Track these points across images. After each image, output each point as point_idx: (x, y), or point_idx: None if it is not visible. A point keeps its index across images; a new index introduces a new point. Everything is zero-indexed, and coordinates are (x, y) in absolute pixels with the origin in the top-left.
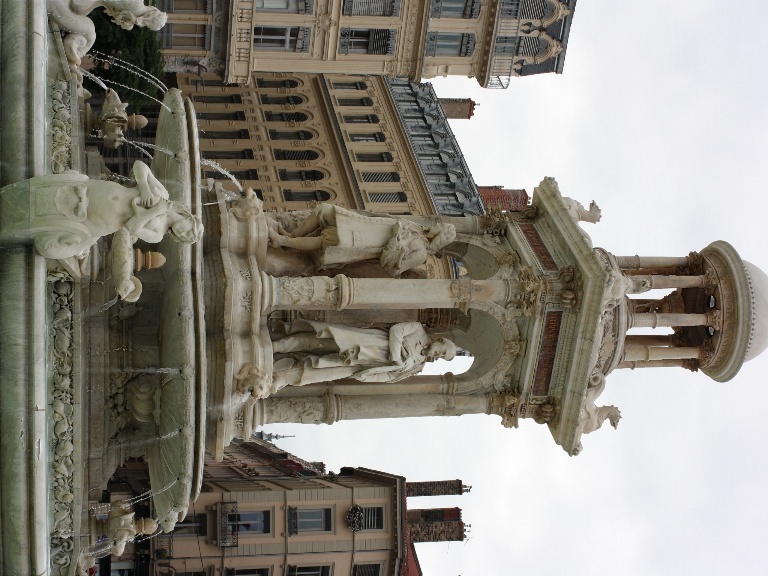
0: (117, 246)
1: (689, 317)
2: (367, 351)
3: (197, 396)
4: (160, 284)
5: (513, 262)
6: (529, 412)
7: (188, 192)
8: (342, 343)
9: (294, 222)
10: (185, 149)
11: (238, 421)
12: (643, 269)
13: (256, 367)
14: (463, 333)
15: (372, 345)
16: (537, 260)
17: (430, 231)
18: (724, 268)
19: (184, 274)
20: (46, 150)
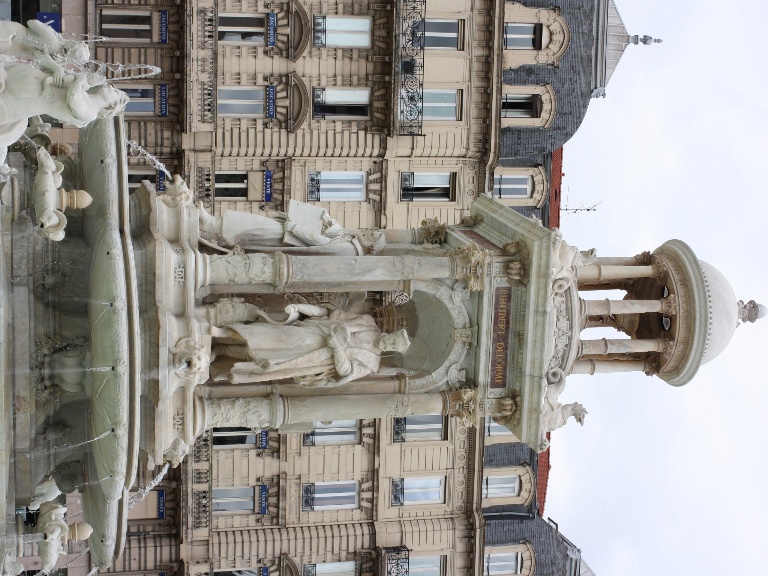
0: None
1: None
2: None
3: None
4: None
5: None
6: (494, 254)
7: None
8: None
9: None
10: None
11: None
12: None
13: None
14: (433, 362)
15: None
16: None
17: None
18: None
19: None
20: None
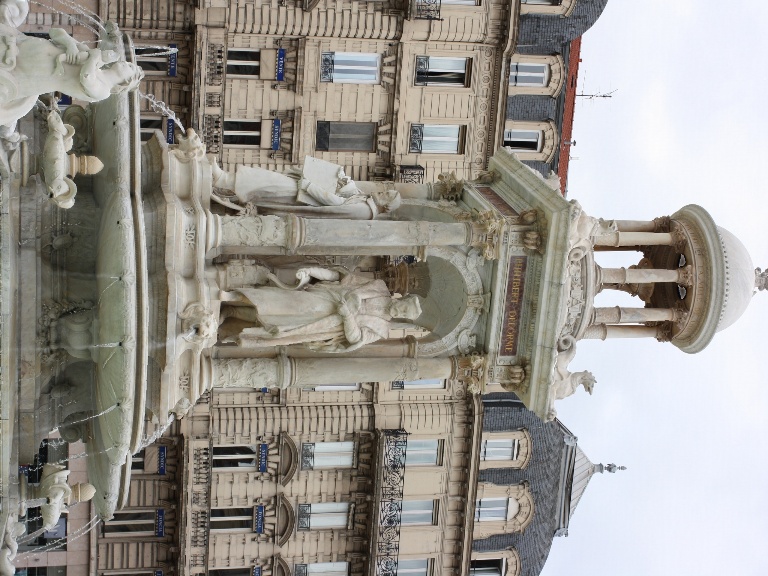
0: None
1: None
2: None
3: None
4: None
5: None
6: (511, 222)
7: None
8: None
9: None
10: None
11: (188, 209)
12: None
13: None
14: (443, 325)
15: None
16: None
17: None
18: None
19: None
20: None
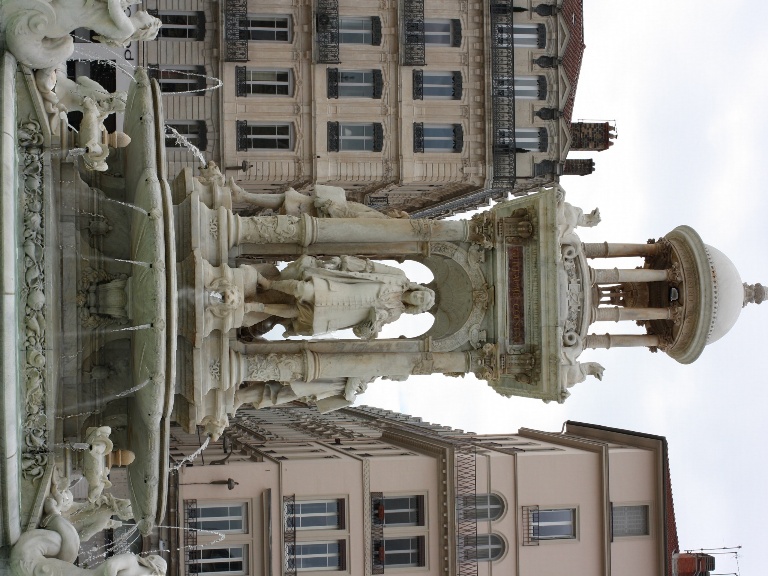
0: (89, 474)
1: (642, 344)
2: (323, 397)
3: (157, 516)
4: (131, 396)
5: (487, 304)
6: None
7: (161, 402)
8: (301, 394)
9: (277, 239)
10: (161, 372)
11: None
12: (626, 252)
13: (217, 420)
14: None
15: (329, 390)
16: (508, 324)
17: (409, 298)
18: (695, 305)
19: (153, 437)
20: (20, 388)
